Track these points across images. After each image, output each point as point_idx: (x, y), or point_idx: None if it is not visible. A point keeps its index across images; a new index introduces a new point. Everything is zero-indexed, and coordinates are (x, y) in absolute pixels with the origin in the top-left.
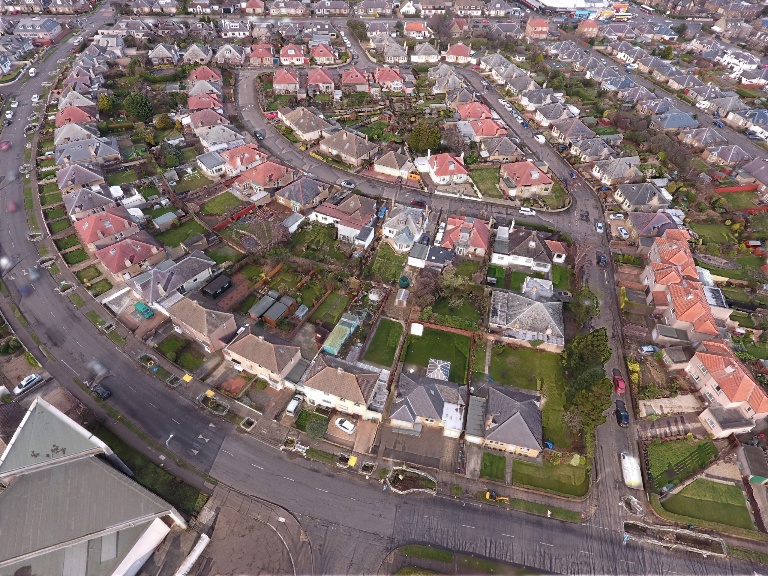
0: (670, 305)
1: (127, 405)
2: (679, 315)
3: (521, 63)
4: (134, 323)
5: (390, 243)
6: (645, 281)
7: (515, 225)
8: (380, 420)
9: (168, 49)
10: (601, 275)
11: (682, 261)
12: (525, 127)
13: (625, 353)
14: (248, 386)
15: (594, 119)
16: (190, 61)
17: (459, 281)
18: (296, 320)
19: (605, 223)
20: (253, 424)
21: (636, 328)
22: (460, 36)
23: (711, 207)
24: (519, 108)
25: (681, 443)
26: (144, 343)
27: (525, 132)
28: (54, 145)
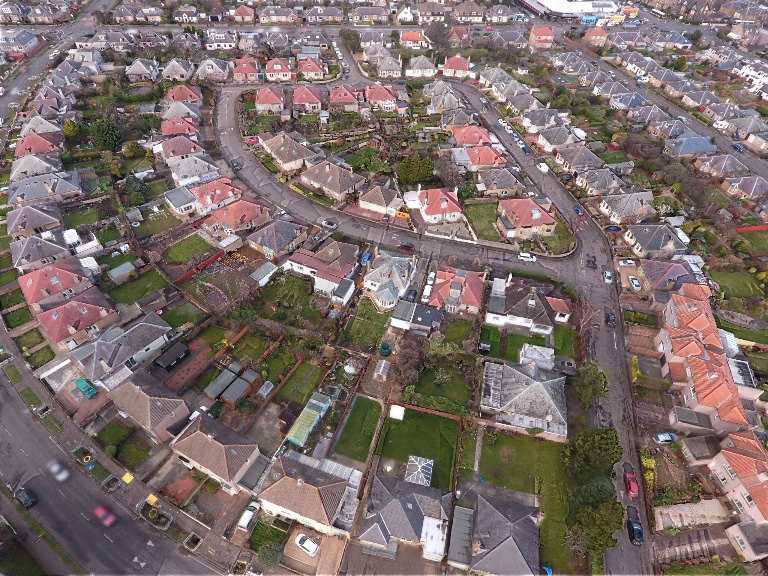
0: (690, 382)
1: (54, 516)
2: (701, 398)
3: (524, 77)
4: (74, 404)
5: (372, 298)
6: (660, 346)
7: (513, 277)
8: (348, 537)
9: (146, 65)
10: (610, 338)
11: (703, 326)
12: (526, 153)
13: (638, 442)
14: (197, 490)
15: (602, 144)
16: (169, 77)
17: (447, 350)
18: (259, 400)
19: (614, 271)
20: (199, 542)
21: (650, 408)
22: (459, 46)
23: (733, 251)
24: (520, 130)
25: (705, 568)
26: (82, 431)
27: (526, 159)
28: None
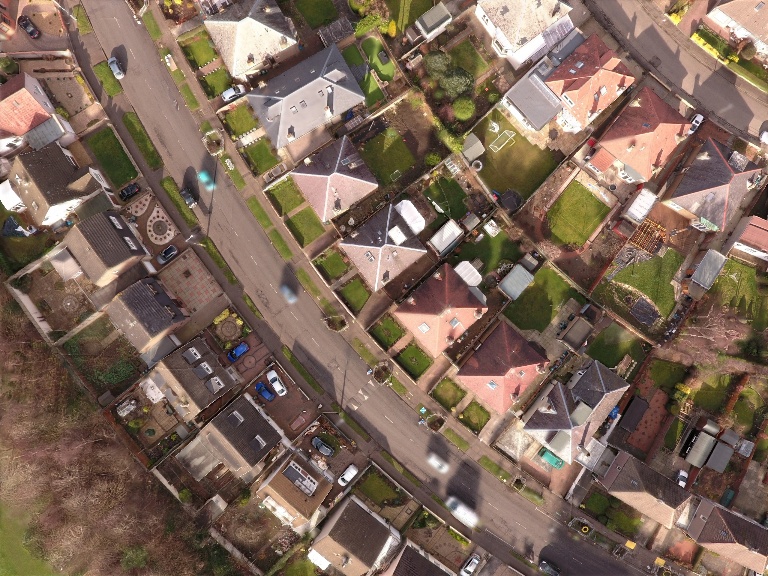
0: None
1: None
2: None
3: None
4: (543, 473)
5: None
6: None
7: None
8: None
9: None
10: None
11: None
12: None
13: None
14: None
15: None
16: None
17: None
18: (737, 457)
19: None
20: None
21: None
22: None
23: None
24: None
25: None
26: (567, 502)
27: None
28: (215, 57)
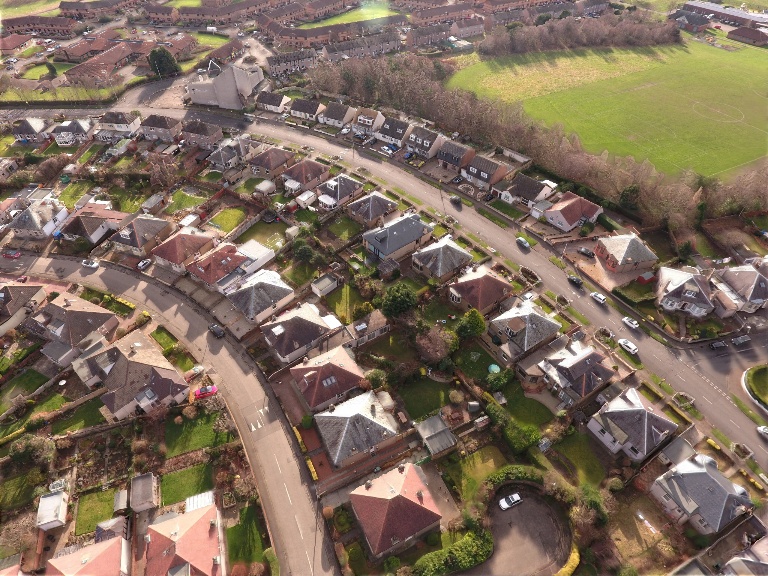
0: None
1: (234, 119)
2: None
3: None
4: None
5: None
6: None
7: None
8: None
9: None
10: None
11: None
12: None
13: None
14: None
15: None
16: None
17: None
18: None
19: None
20: None
21: None
22: None
23: None
24: None
25: None
26: None
27: None
28: None
